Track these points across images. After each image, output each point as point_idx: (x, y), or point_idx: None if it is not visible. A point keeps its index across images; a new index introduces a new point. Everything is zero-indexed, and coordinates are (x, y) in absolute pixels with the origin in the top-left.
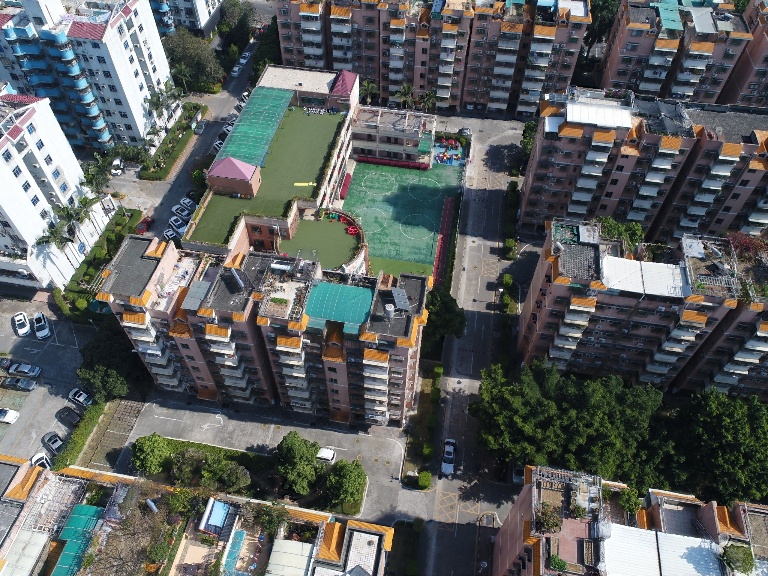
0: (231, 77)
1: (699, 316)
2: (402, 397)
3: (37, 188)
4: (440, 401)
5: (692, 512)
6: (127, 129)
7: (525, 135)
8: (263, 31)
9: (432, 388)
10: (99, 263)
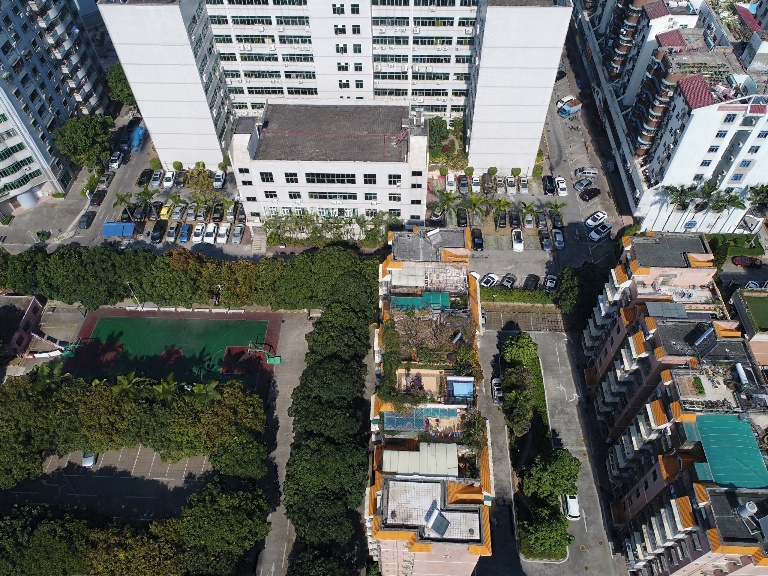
0: None
1: None
2: (663, 575)
3: (719, 158)
4: None
5: None
6: None
7: None
8: None
9: None
10: None
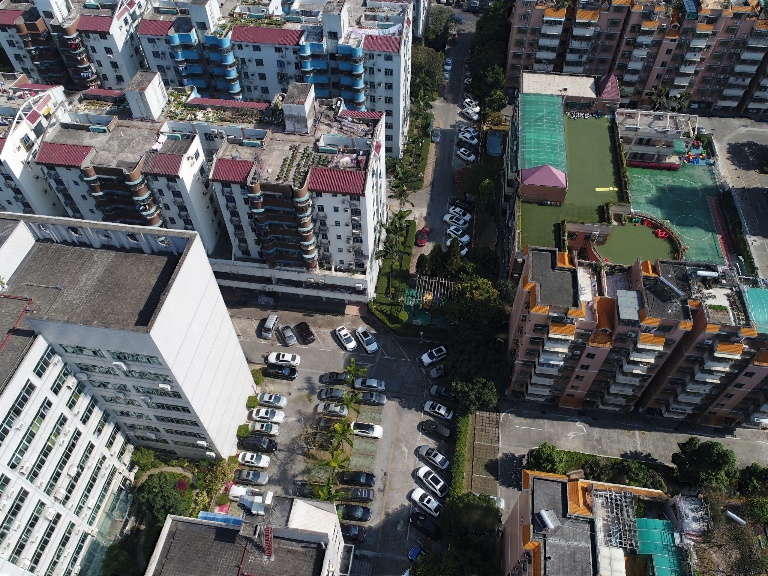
0: None
1: None
2: None
3: (375, 202)
4: None
5: None
6: (387, 140)
7: None
8: (457, 37)
9: None
10: (396, 275)
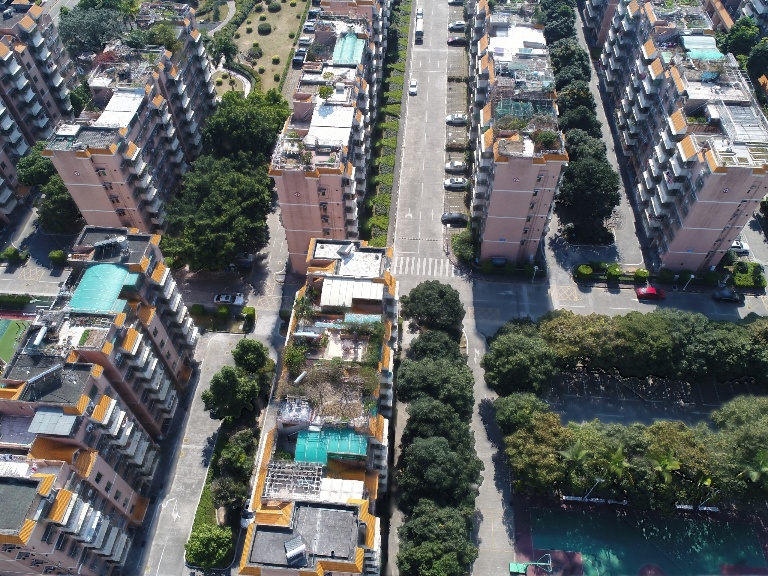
0: None
1: (158, 98)
2: None
3: None
4: None
5: (295, 121)
6: None
7: None
8: None
9: None
10: None
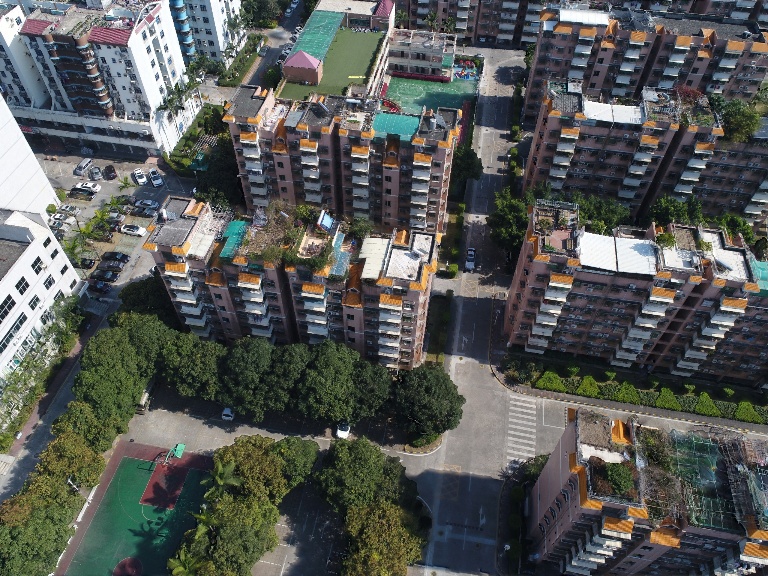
0: (285, 17)
1: (653, 139)
2: (438, 206)
3: (159, 67)
4: (463, 228)
5: (641, 238)
6: (210, 45)
7: (528, 53)
8: None
9: (457, 216)
10: (194, 139)
